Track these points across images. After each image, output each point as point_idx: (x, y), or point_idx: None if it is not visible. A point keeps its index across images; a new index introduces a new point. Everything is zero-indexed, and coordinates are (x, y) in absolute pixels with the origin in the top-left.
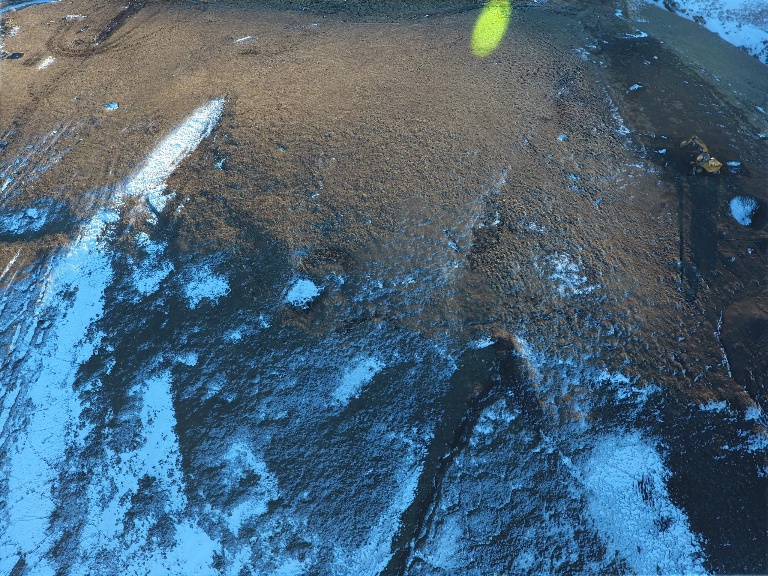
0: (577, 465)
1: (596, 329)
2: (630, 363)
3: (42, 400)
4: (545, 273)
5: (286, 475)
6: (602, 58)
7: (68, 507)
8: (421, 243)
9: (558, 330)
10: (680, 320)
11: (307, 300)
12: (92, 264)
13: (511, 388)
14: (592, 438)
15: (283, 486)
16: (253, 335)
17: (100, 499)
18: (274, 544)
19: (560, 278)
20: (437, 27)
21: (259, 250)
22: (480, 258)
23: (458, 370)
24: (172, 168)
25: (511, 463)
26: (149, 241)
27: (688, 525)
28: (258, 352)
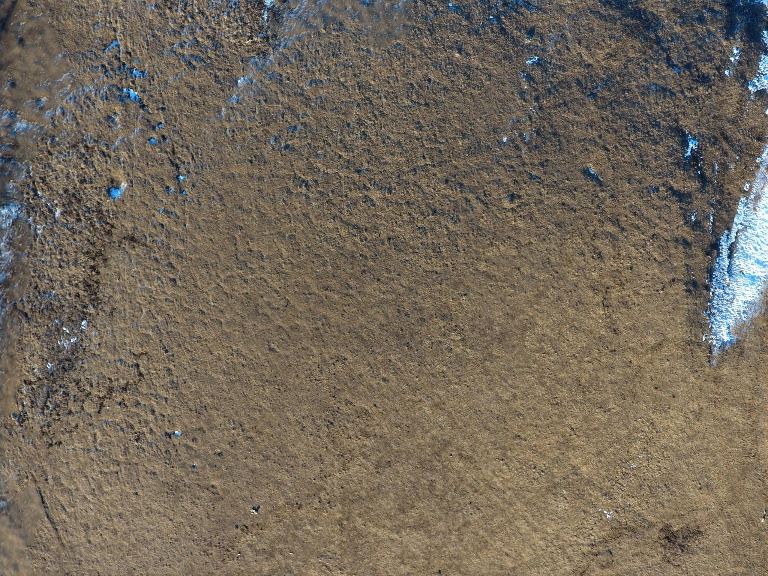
0: None
1: None
2: None
3: None
4: None
5: None
6: None
7: None
8: None
9: None
10: None
11: None
12: None
13: None
14: None
15: None
16: None
17: None
18: None
19: None
20: None
21: None
22: None
23: None
24: None
25: None
26: (765, 2)
27: None
28: None
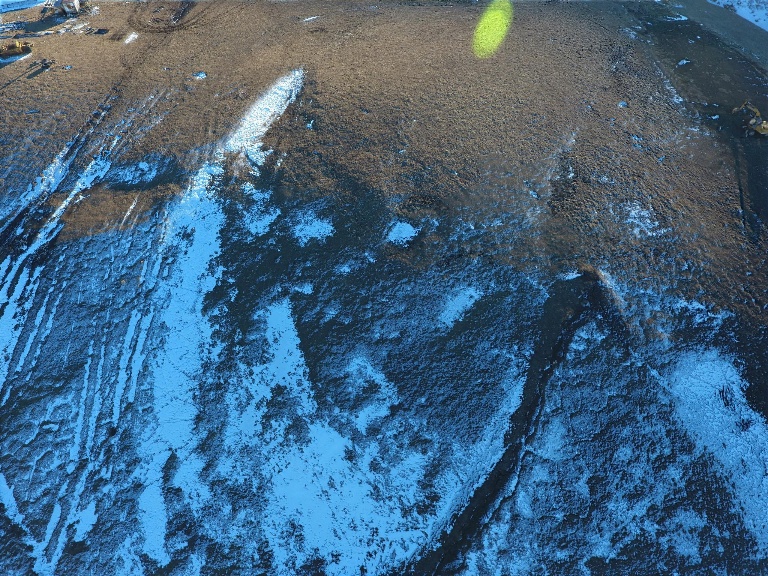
0: (664, 376)
1: (671, 265)
2: (705, 293)
3: (175, 323)
4: (620, 218)
5: (404, 384)
6: (649, 37)
7: (210, 411)
8: (505, 192)
9: (637, 265)
10: (746, 258)
11: (406, 239)
12: (205, 210)
13: (600, 312)
14: (676, 354)
15: (402, 393)
16: (361, 268)
17: (238, 404)
18: (399, 441)
19: (634, 222)
20: (490, 9)
21: (357, 197)
22: (560, 205)
23: (550, 298)
24: (265, 129)
25: (605, 374)
26: (255, 190)
27: (767, 426)
28: (367, 282)
